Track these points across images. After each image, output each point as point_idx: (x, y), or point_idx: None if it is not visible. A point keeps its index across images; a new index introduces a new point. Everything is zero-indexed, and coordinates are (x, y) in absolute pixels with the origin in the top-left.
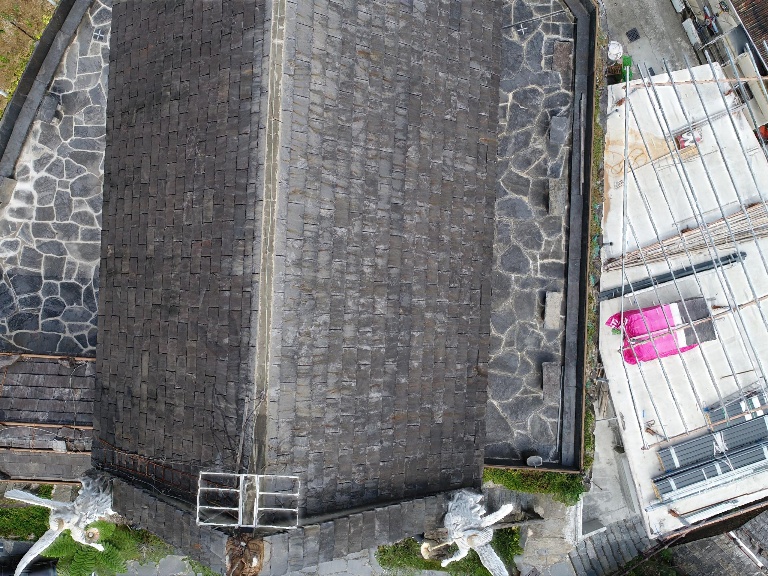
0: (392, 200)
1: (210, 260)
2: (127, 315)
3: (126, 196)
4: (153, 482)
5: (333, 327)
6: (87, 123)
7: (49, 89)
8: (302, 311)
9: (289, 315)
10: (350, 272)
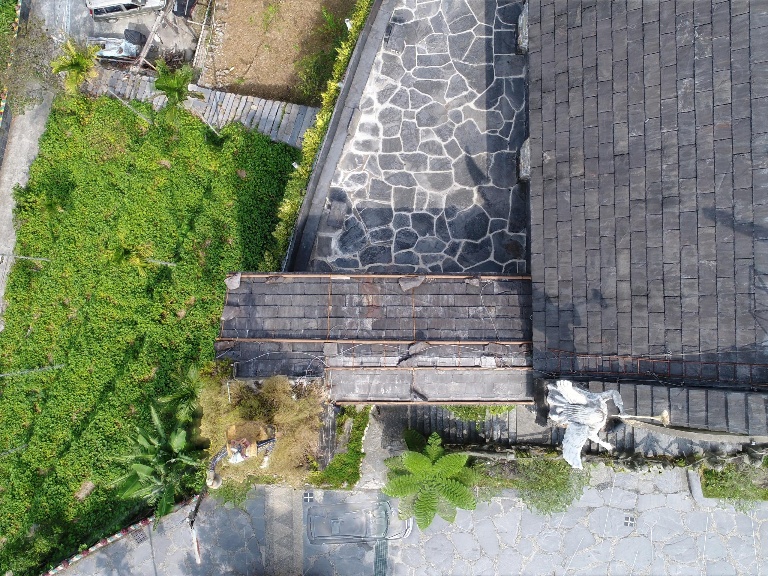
0: None
1: (732, 141)
2: (585, 217)
3: (572, 98)
4: (656, 378)
5: None
6: (430, 52)
7: (390, 19)
8: None
9: None
10: None
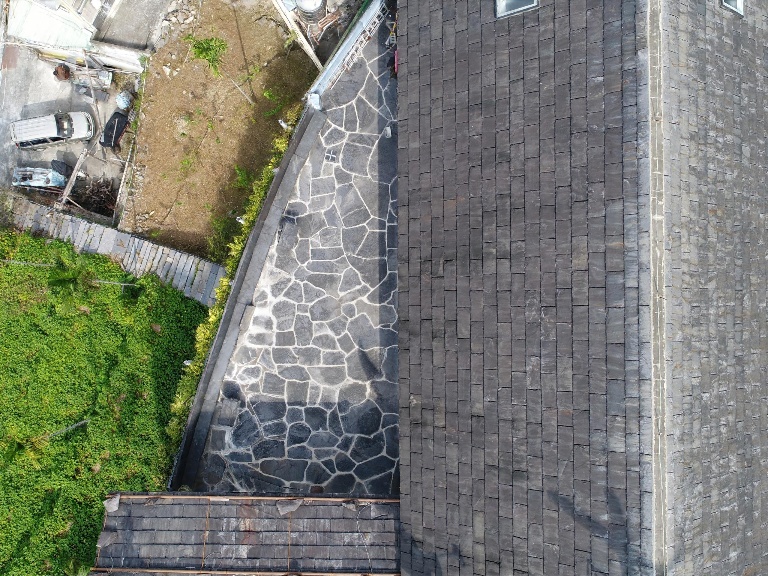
0: (735, 353)
1: (573, 431)
2: (446, 471)
3: (435, 348)
4: None
5: (704, 495)
6: (324, 245)
7: (283, 212)
8: (685, 486)
9: (677, 493)
10: (712, 435)
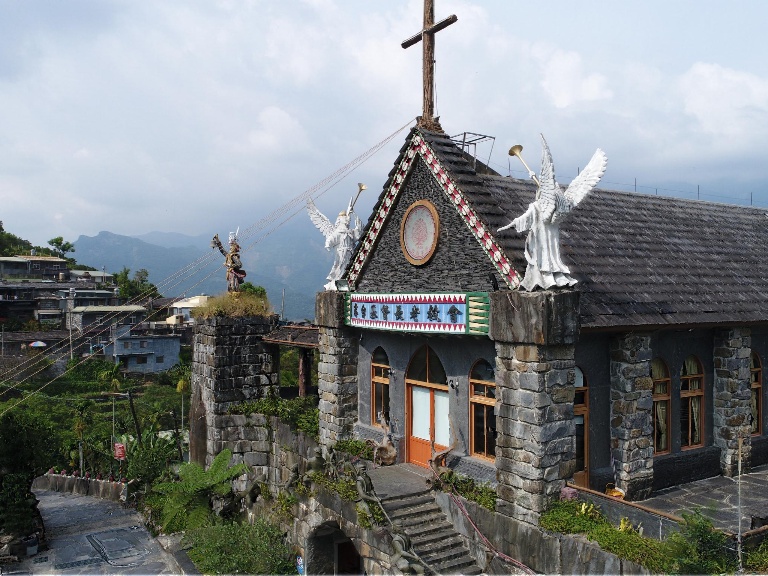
0: None
1: None
2: None
3: None
4: None
5: None
6: None
7: None
8: None
9: None
10: None
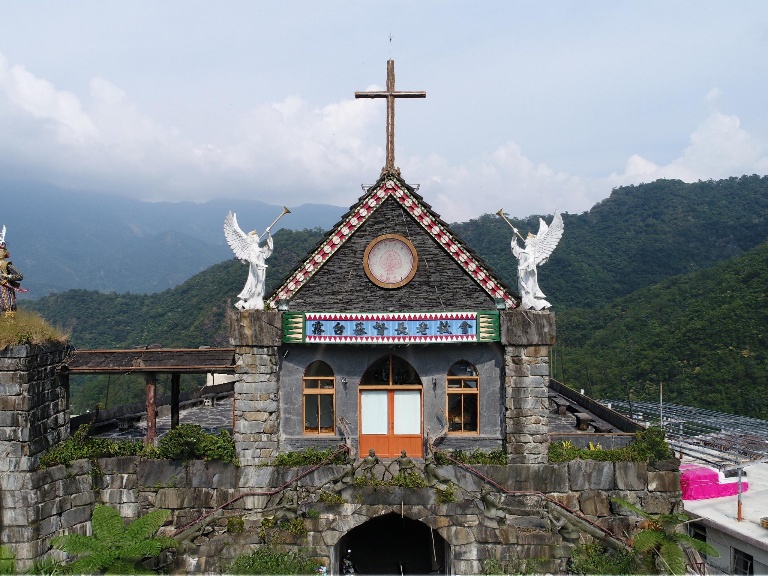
0: None
1: None
2: None
3: None
4: None
5: None
6: None
7: None
8: None
9: None
10: None
